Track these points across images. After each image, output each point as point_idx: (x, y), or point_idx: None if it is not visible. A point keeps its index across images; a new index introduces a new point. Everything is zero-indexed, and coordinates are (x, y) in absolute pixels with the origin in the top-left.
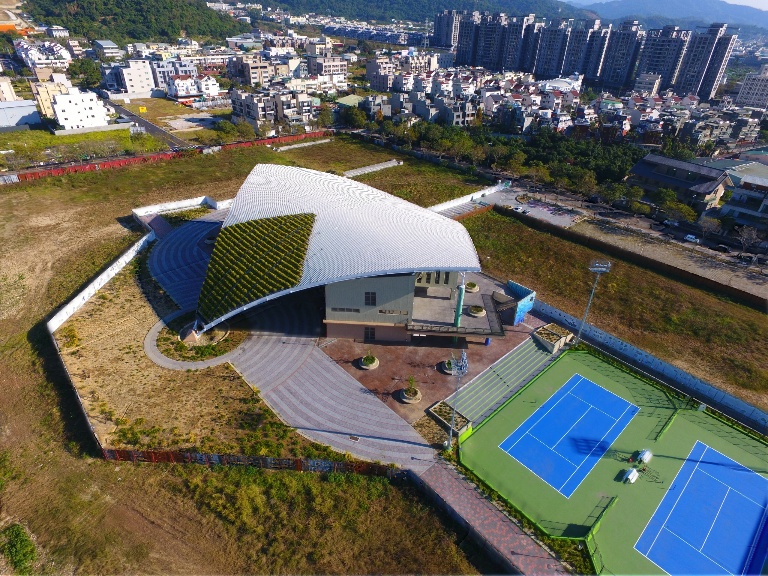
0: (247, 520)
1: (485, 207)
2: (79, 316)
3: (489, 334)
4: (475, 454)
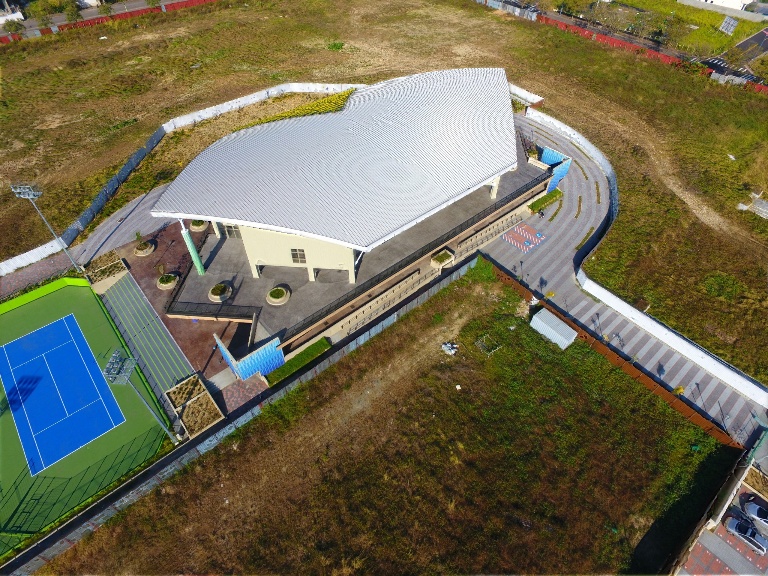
0: (86, 181)
1: (703, 418)
2: (310, 94)
3: (173, 298)
4: (75, 296)
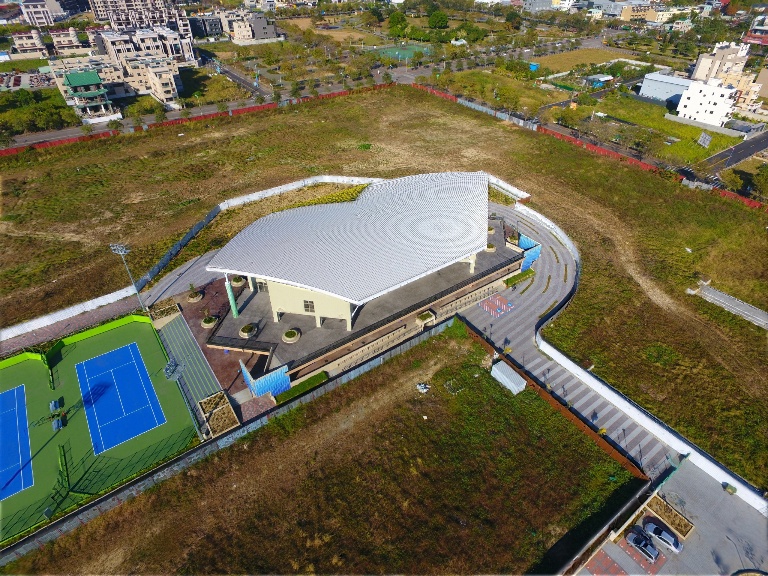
0: (157, 244)
1: (620, 454)
2: (338, 185)
3: (213, 333)
4: (139, 329)
